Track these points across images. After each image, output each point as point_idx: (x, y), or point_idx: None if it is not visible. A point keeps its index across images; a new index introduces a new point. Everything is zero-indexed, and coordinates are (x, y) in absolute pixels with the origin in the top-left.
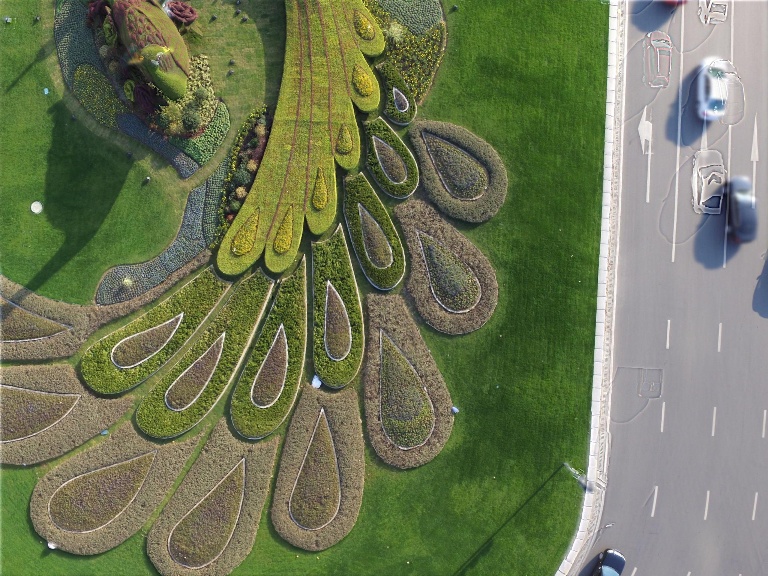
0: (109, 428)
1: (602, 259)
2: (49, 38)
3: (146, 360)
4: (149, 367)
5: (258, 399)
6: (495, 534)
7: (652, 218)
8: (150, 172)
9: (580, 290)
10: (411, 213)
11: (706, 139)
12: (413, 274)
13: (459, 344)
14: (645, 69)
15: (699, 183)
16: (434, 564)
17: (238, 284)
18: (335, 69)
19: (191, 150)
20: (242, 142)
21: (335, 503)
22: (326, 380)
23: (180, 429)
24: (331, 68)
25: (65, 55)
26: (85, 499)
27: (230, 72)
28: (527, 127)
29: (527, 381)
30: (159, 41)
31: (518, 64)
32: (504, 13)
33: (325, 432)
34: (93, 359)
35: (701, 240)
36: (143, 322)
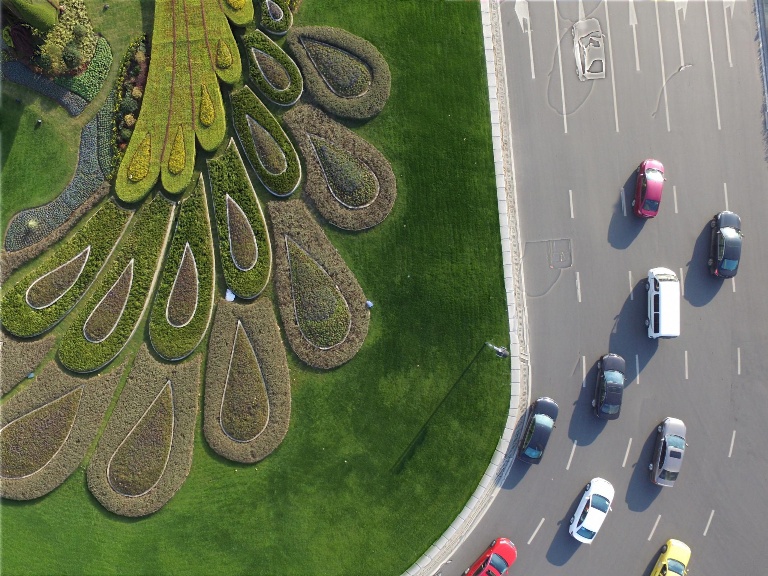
0: (35, 371)
1: (495, 139)
2: None
3: (60, 298)
4: (64, 304)
5: (174, 319)
6: (427, 422)
7: (540, 93)
8: (41, 115)
9: (477, 171)
10: (299, 117)
11: (583, 10)
12: (309, 176)
13: (365, 239)
14: None
15: (581, 53)
16: (371, 459)
17: (141, 211)
18: None
19: (78, 88)
20: (126, 72)
21: (264, 412)
22: (238, 291)
23: (103, 360)
24: None
25: None
26: (20, 443)
27: (106, 7)
28: (403, 20)
29: (437, 267)
30: None
31: None
32: None
33: (245, 343)
34: (9, 304)
35: (591, 108)
36: (52, 261)
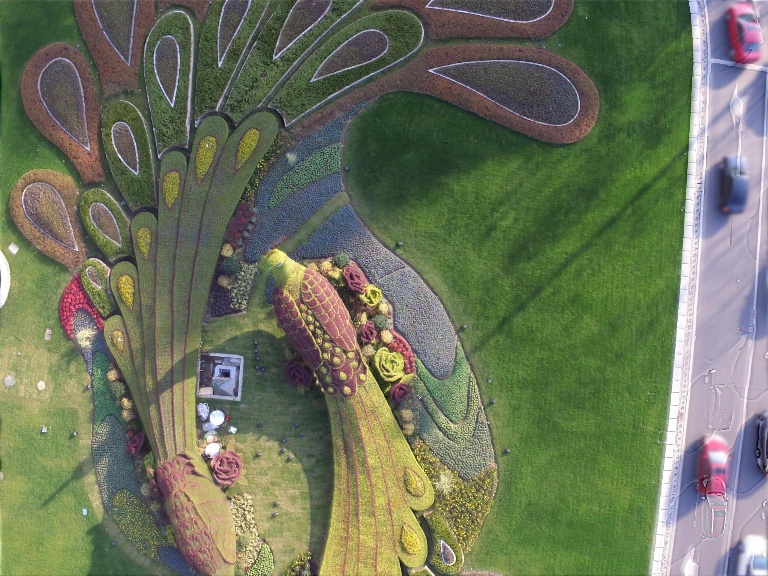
0: None
1: None
2: (87, 455)
3: None
4: None
5: None
6: None
7: None
8: None
9: None
10: None
11: None
12: None
13: None
14: (697, 514)
15: None
16: None
17: None
18: (383, 529)
19: None
20: None
21: None
22: None
23: None
24: (379, 528)
25: (104, 478)
26: None
27: (275, 515)
28: (574, 575)
29: None
30: (207, 540)
31: (569, 511)
32: (558, 457)
33: None
34: None
35: None
36: None
